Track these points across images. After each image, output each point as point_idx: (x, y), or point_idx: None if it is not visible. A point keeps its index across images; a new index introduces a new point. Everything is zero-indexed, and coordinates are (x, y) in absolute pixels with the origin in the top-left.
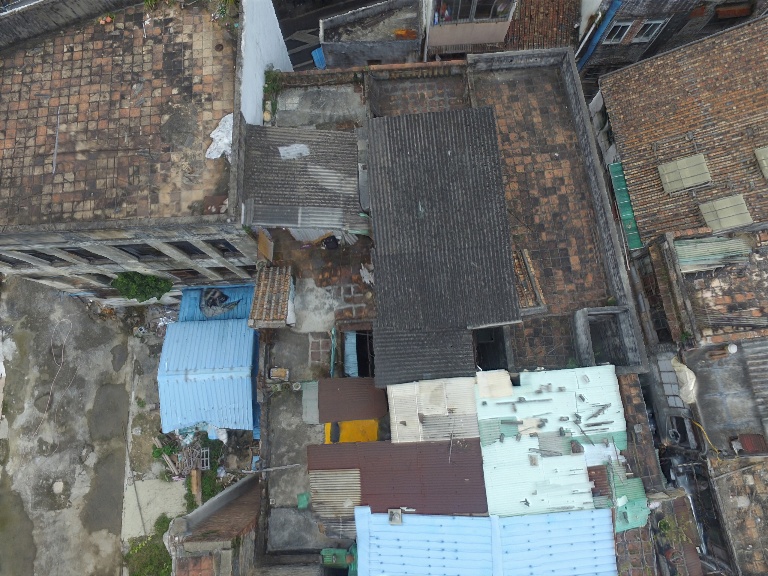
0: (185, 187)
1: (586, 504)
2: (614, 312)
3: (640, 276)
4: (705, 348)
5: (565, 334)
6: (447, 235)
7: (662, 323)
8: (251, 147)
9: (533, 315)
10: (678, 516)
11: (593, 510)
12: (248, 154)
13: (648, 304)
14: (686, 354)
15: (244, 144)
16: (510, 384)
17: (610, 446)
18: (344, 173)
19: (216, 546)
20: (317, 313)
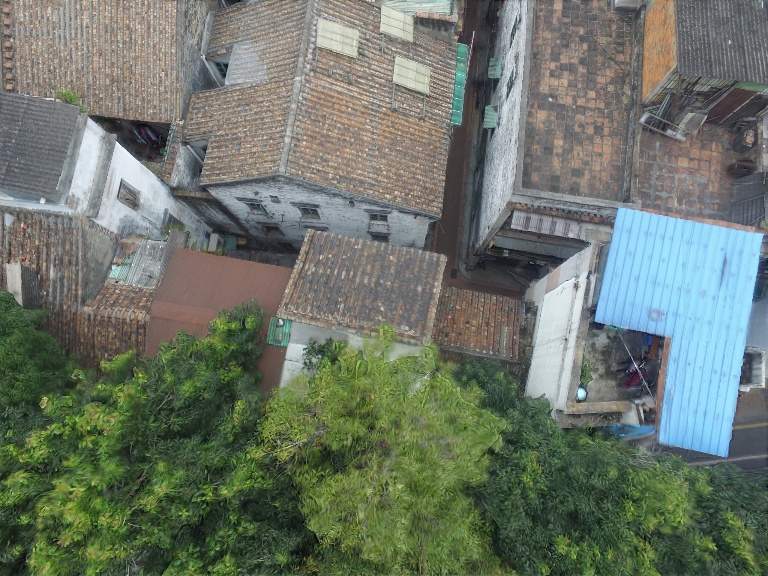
0: None
1: None
2: None
3: None
4: None
5: None
6: None
7: None
8: None
9: None
10: None
11: None
12: None
13: None
14: None
15: None
16: None
17: None
18: None
19: None
20: None
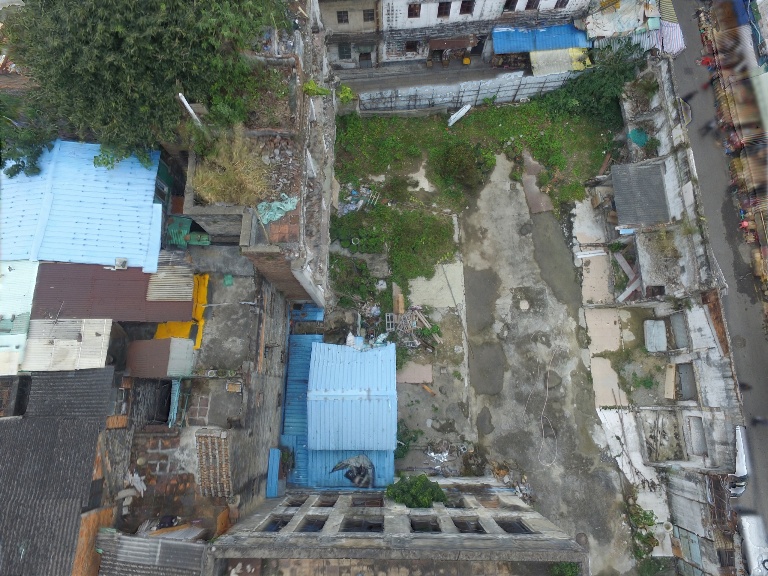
0: None
1: None
2: None
3: None
4: None
5: None
6: (5, 518)
7: None
8: None
9: None
10: None
11: None
12: None
13: None
14: None
15: None
16: None
17: None
18: None
19: (254, 249)
20: None
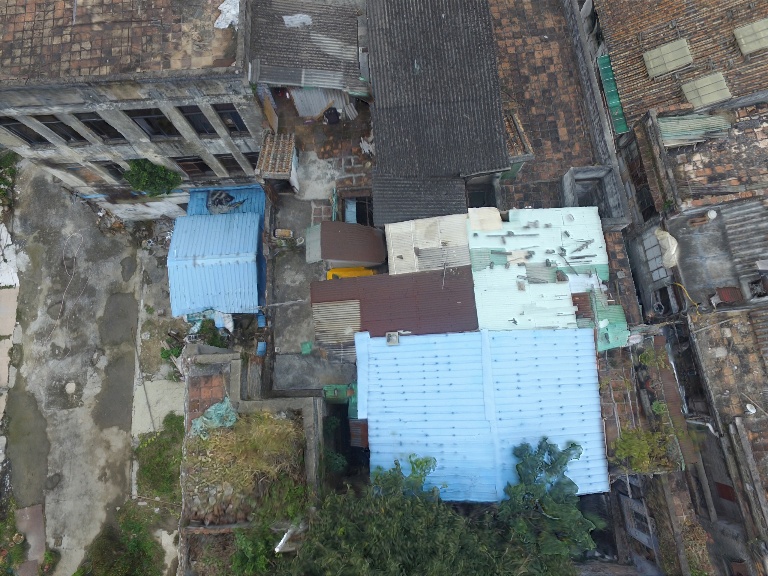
0: (195, 54)
1: (570, 324)
2: (599, 176)
3: (627, 164)
4: (686, 217)
5: (553, 199)
6: (441, 89)
7: (647, 202)
8: (257, 15)
9: (523, 181)
10: None
11: (576, 329)
12: (254, 21)
13: (634, 189)
14: (668, 223)
15: (251, 10)
16: (500, 219)
17: (593, 276)
18: (345, 42)
19: (226, 358)
20: (319, 182)
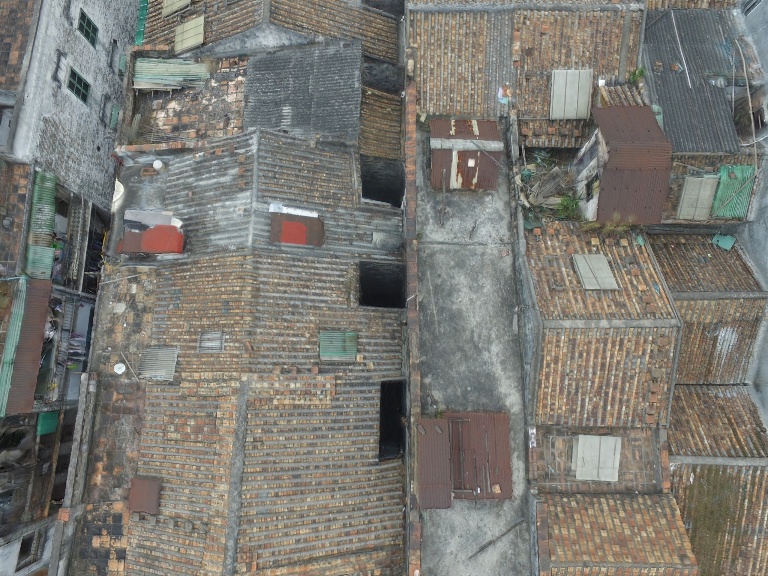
0: None
1: None
2: None
3: None
4: (142, 165)
5: None
6: None
7: None
8: None
9: None
10: (30, 304)
11: None
12: None
13: None
14: (124, 169)
15: None
16: None
17: None
18: None
19: None
20: None
